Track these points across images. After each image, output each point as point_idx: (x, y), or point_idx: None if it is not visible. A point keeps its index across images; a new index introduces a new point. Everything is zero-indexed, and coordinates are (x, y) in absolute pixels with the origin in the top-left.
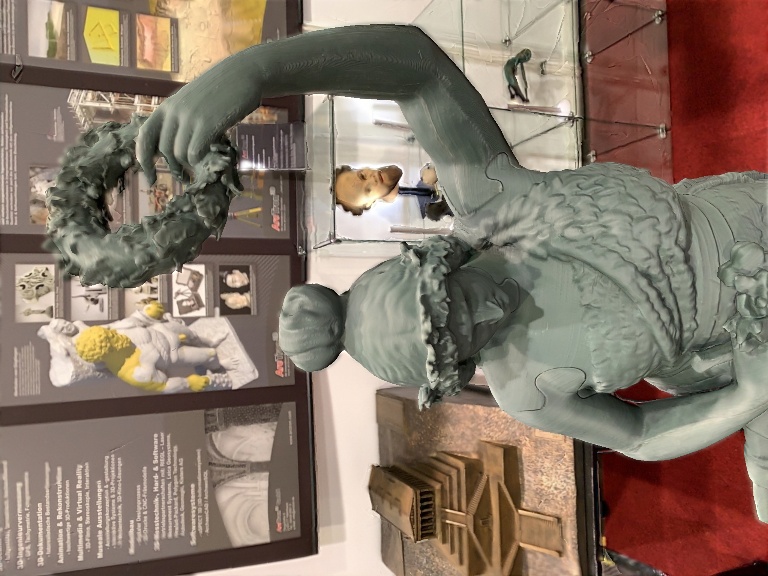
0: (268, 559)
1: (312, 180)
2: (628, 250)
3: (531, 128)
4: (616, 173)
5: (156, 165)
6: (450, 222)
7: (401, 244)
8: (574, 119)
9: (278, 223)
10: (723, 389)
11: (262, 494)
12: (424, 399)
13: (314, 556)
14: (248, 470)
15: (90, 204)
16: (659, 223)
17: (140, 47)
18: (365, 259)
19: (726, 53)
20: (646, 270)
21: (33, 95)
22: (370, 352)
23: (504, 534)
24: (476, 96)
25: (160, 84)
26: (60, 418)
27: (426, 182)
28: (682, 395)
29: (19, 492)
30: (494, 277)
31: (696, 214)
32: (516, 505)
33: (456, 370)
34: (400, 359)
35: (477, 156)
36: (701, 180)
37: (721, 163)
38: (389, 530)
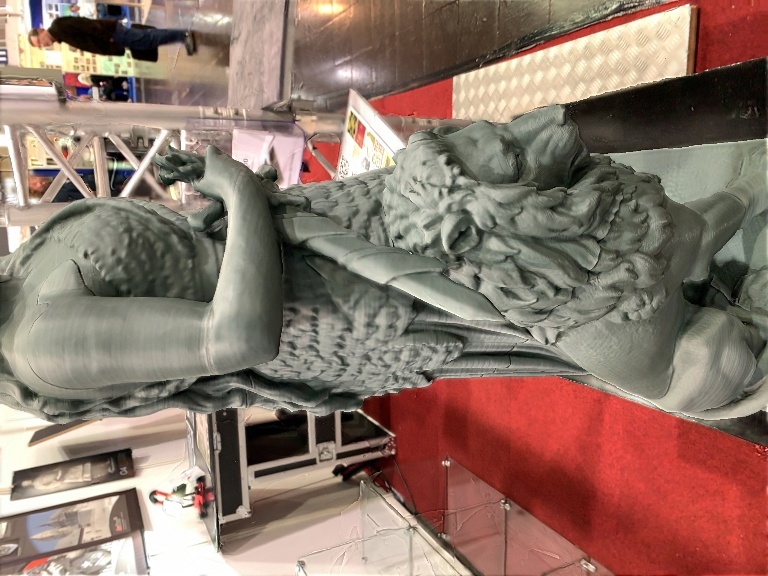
0: None
1: None
2: None
3: None
4: None
5: None
6: None
7: None
8: None
9: None
10: None
11: None
12: None
13: None
14: None
15: None
16: None
17: None
18: None
19: (553, 469)
20: None
21: None
22: None
23: None
24: None
25: None
26: None
27: None
28: None
29: None
30: None
31: None
32: None
33: None
34: None
35: None
36: None
37: (637, 529)
38: None
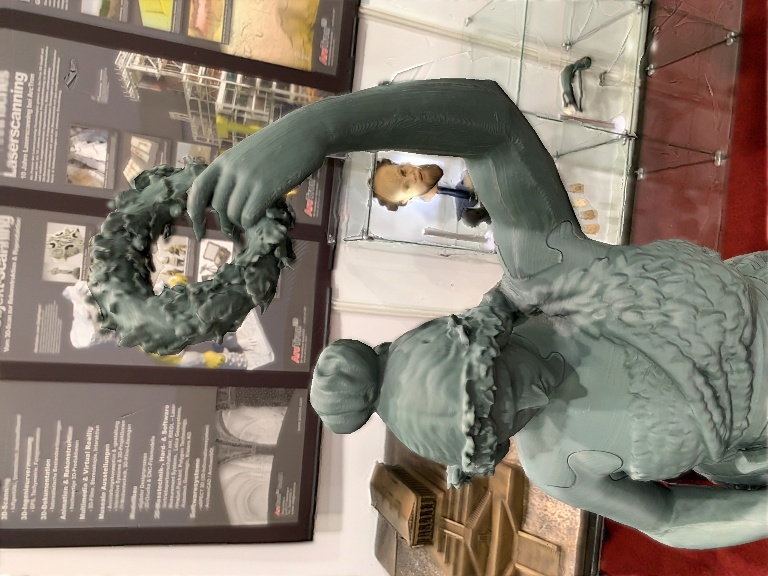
0: (263, 539)
1: (350, 168)
2: (689, 345)
3: (580, 138)
4: (686, 257)
5: (196, 137)
6: (486, 230)
7: (451, 319)
8: (627, 137)
9: (311, 208)
10: (765, 492)
11: (265, 476)
12: (454, 482)
13: (308, 542)
14: (254, 451)
15: (134, 256)
16: (726, 319)
17: (193, 14)
18: (394, 254)
19: None
20: (704, 367)
21: (81, 53)
22: (404, 426)
23: (501, 552)
24: (548, 161)
25: (209, 55)
26: (76, 379)
27: (466, 186)
28: (717, 483)
29: (30, 446)
30: (540, 350)
31: (763, 305)
32: (517, 526)
33: (493, 460)
34: (435, 440)
35: (540, 223)
36: (767, 254)
37: None
38: (385, 526)
